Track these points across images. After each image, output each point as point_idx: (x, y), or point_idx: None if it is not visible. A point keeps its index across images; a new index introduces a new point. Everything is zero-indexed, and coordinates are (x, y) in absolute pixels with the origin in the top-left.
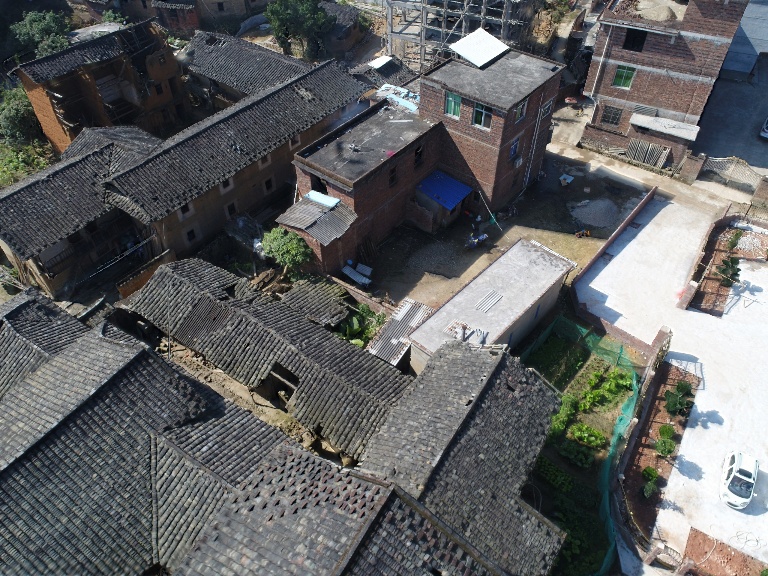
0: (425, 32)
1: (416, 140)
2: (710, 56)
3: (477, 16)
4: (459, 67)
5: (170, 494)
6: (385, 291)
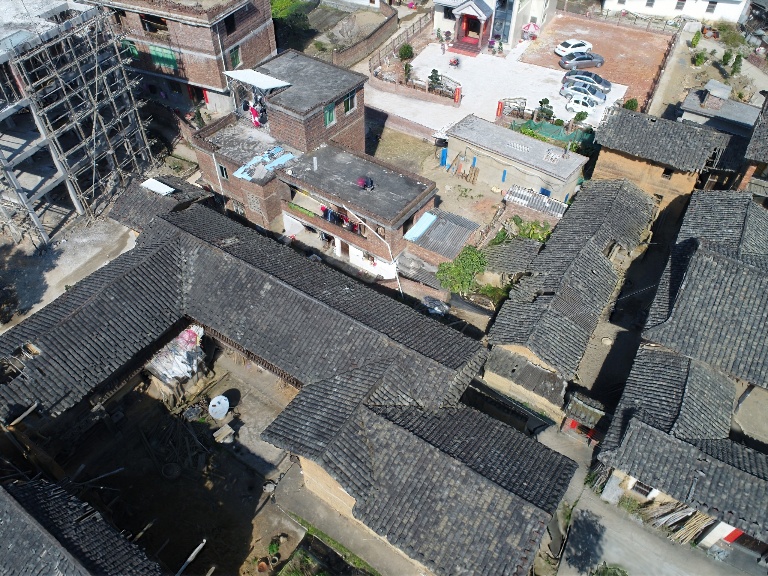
0: (62, 164)
1: None
2: (264, 4)
3: (106, 102)
4: (283, 96)
5: (763, 247)
6: None
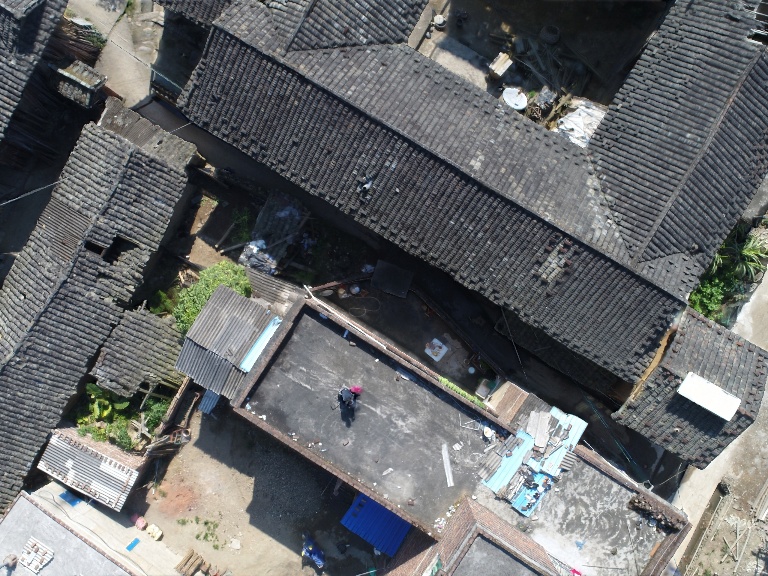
0: None
1: (375, 499)
2: None
3: None
4: None
5: None
6: (214, 427)
